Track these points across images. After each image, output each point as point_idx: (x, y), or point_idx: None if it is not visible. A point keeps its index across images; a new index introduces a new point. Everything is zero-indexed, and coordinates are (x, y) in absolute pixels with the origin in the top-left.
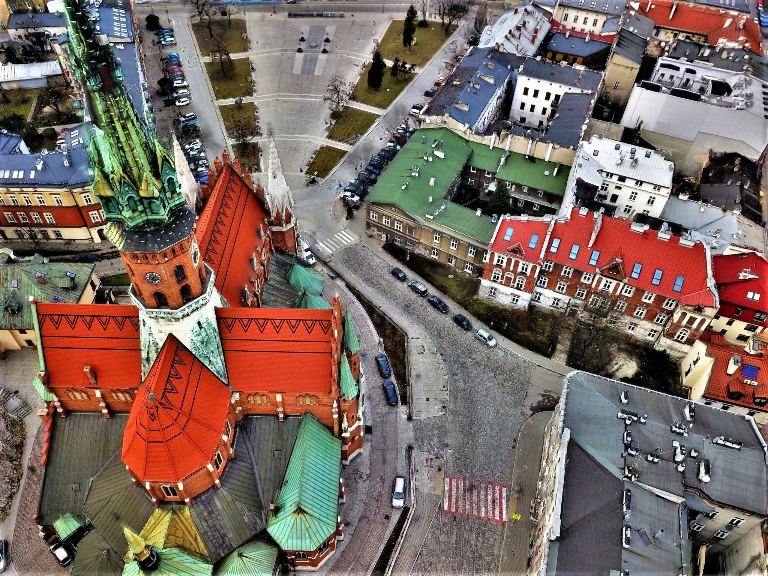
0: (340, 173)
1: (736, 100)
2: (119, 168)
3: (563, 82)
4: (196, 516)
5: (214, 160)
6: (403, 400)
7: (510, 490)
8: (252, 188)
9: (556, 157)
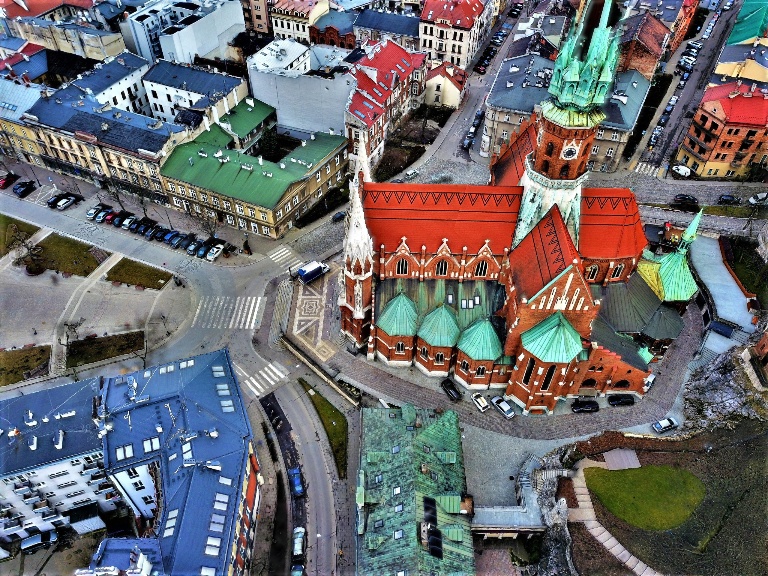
0: None
1: (209, 3)
2: None
3: (125, 74)
4: None
5: (361, 188)
6: None
7: None
8: None
9: (239, 97)
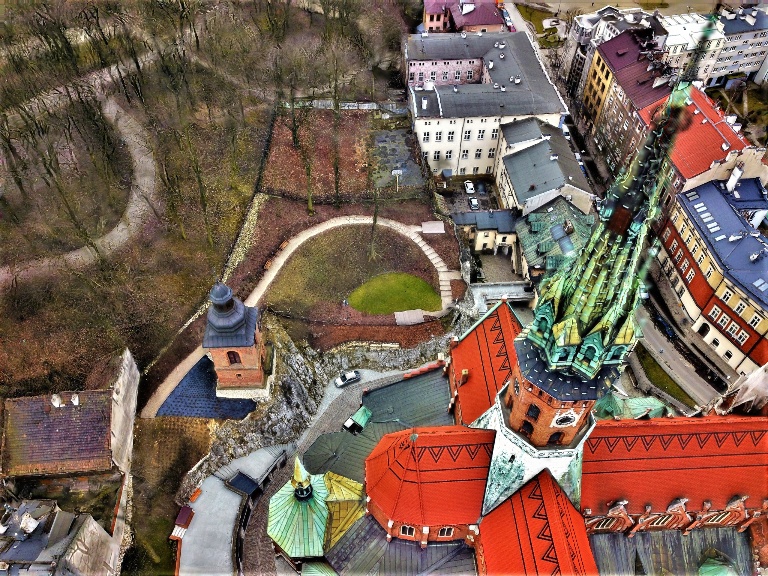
0: None
1: None
2: (558, 291)
3: None
4: (360, 525)
5: None
6: None
7: None
8: None
9: None
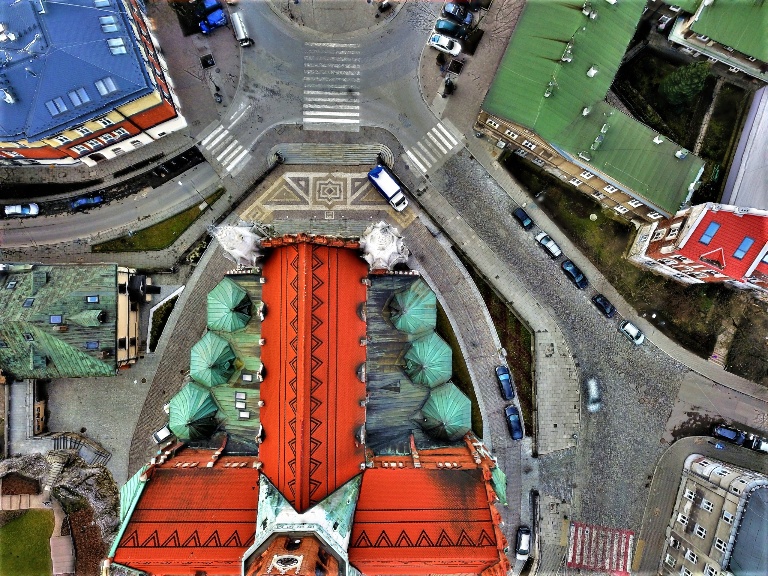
0: None
1: None
2: None
3: None
4: None
5: (283, 240)
6: (528, 431)
7: (638, 538)
8: (342, 245)
9: None
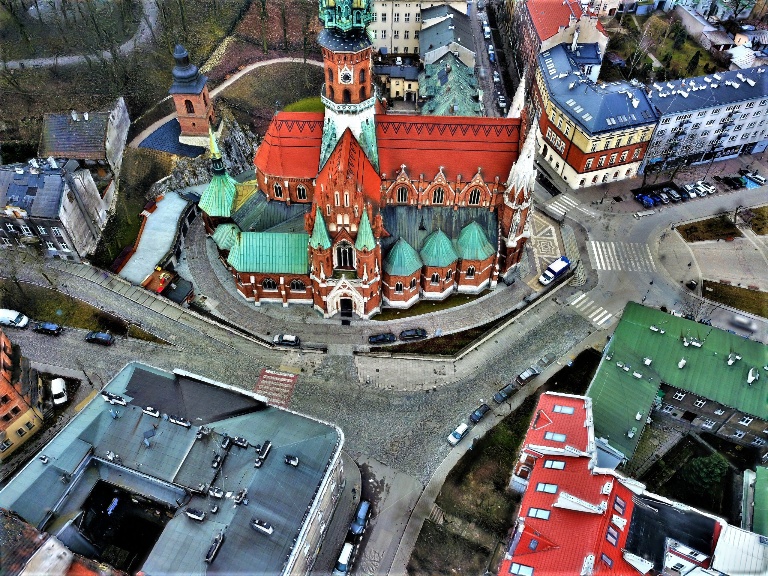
0: (723, 313)
1: None
2: None
3: None
4: (253, 197)
5: None
6: (375, 349)
7: None
8: None
9: None
